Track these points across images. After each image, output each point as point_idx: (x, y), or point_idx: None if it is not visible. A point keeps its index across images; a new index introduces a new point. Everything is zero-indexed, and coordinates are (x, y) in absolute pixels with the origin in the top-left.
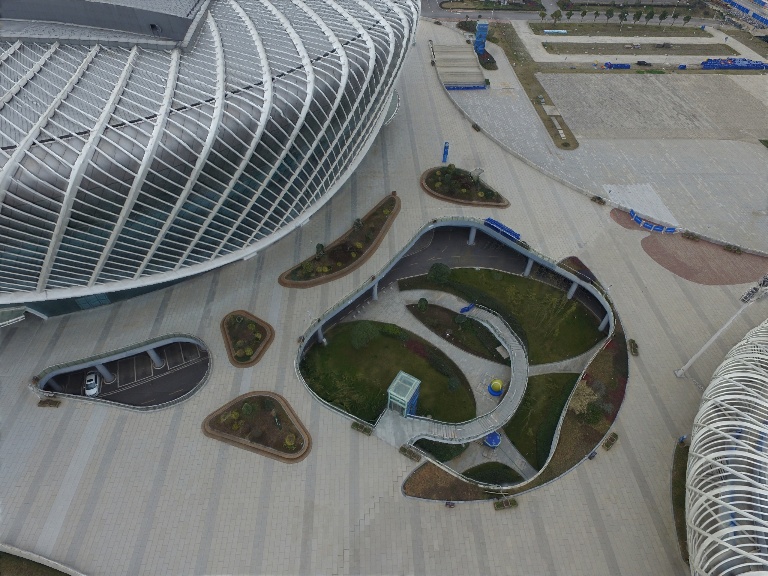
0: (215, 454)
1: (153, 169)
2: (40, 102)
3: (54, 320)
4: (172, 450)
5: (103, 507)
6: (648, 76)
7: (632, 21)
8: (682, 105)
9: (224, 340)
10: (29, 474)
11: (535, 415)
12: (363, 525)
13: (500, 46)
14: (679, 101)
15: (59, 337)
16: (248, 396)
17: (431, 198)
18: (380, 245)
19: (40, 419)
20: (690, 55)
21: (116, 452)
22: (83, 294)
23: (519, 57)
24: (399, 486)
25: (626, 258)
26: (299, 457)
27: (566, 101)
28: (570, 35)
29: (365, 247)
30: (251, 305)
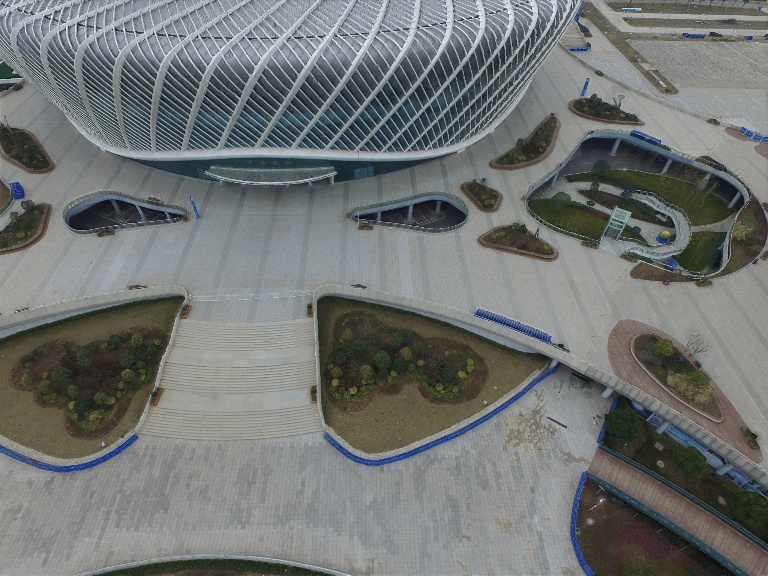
0: (495, 256)
1: (475, 52)
2: (407, 5)
3: (339, 184)
4: (464, 253)
5: (434, 279)
6: (722, 43)
7: (696, 2)
8: (757, 65)
9: (468, 198)
10: (375, 263)
11: (697, 253)
12: (612, 291)
13: (589, 19)
14: (753, 62)
15: (349, 194)
16: (503, 226)
17: (582, 118)
18: (555, 146)
19: (364, 236)
20: (753, 29)
21: (427, 253)
22: (377, 158)
23: (607, 28)
24: (628, 274)
25: (746, 157)
26: (554, 258)
27: (658, 60)
28: (645, 12)
29: (546, 146)
30: (477, 179)
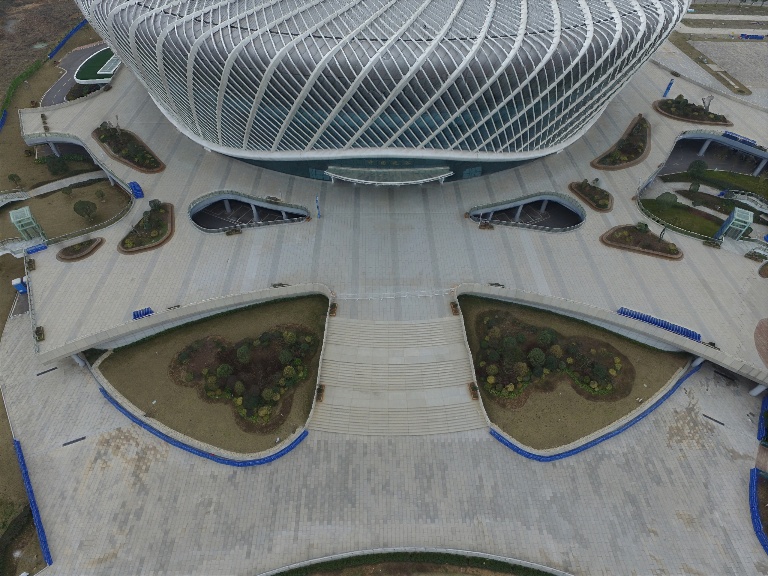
0: (621, 255)
1: None
2: (544, 7)
3: (448, 184)
4: (590, 253)
5: (568, 278)
6: None
7: (747, 3)
8: None
9: (579, 198)
10: (504, 262)
11: None
12: (745, 291)
13: None
14: None
15: (460, 193)
16: (622, 226)
17: (670, 119)
18: (651, 147)
19: (487, 235)
20: None
21: (553, 253)
22: (493, 158)
23: None
24: (756, 273)
25: None
26: (680, 257)
27: (724, 61)
28: (698, 13)
29: (643, 147)
30: (582, 179)
